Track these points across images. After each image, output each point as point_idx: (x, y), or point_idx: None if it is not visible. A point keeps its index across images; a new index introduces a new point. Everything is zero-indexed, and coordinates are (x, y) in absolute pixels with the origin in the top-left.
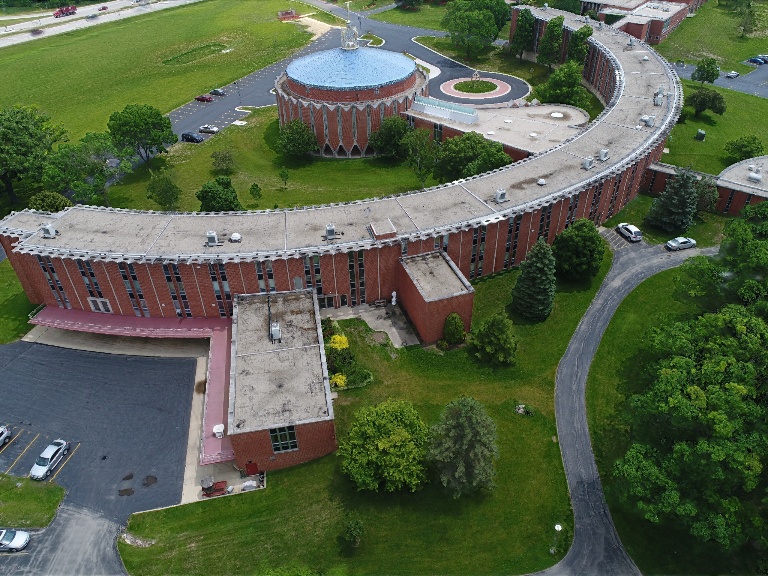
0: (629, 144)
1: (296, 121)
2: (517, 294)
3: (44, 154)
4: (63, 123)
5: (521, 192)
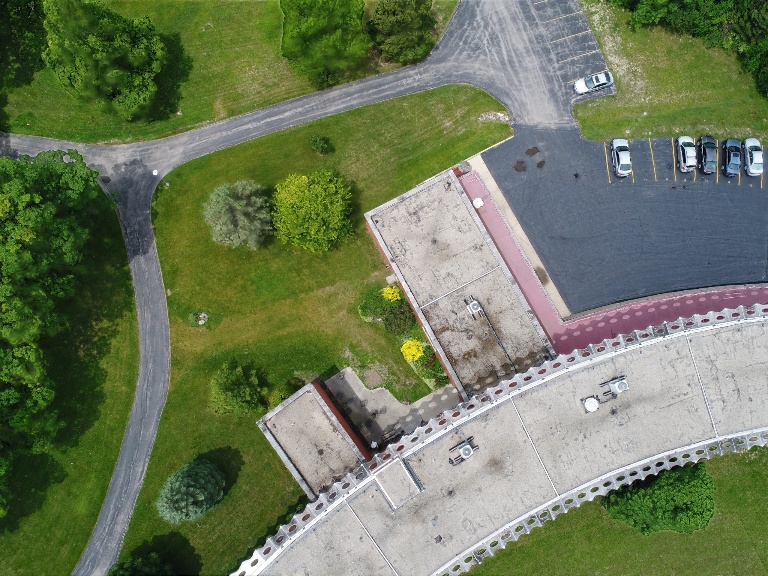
0: None
1: None
2: (215, 474)
3: None
4: None
5: None
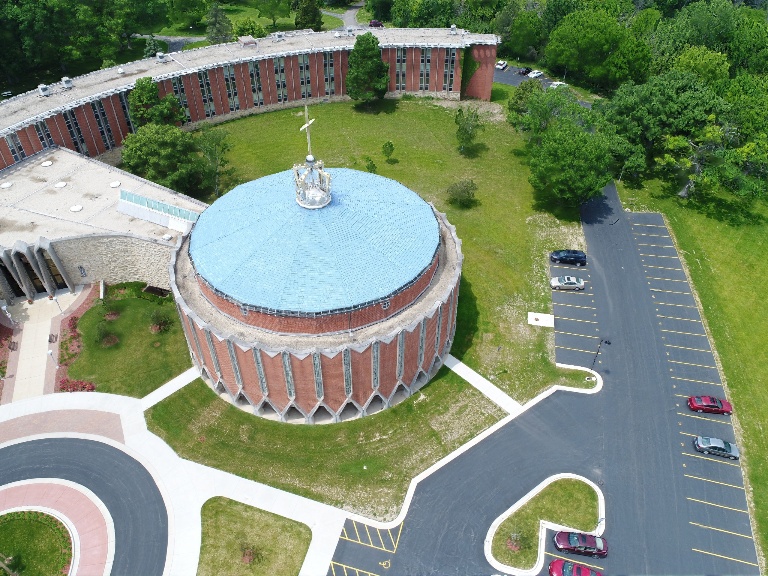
0: None
1: None
2: None
3: (760, 240)
4: (688, 165)
5: (142, 67)
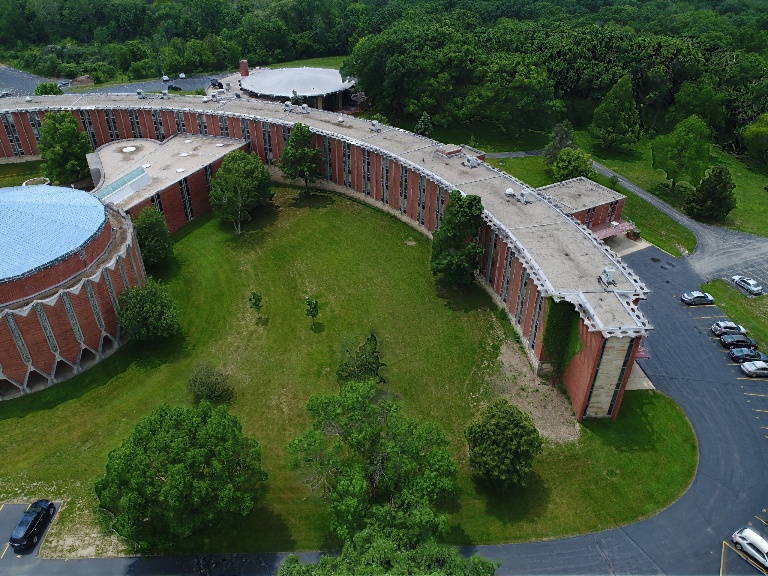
0: (257, 105)
1: (136, 288)
2: None
3: None
4: None
5: (357, 125)
